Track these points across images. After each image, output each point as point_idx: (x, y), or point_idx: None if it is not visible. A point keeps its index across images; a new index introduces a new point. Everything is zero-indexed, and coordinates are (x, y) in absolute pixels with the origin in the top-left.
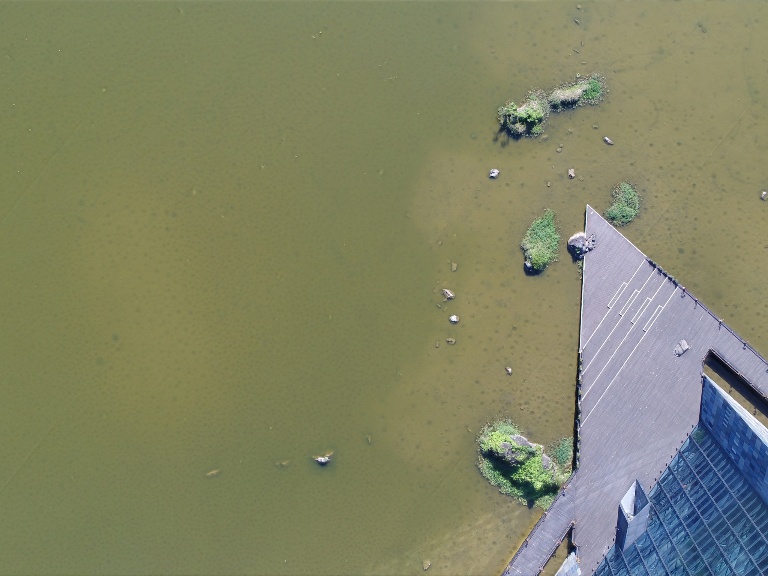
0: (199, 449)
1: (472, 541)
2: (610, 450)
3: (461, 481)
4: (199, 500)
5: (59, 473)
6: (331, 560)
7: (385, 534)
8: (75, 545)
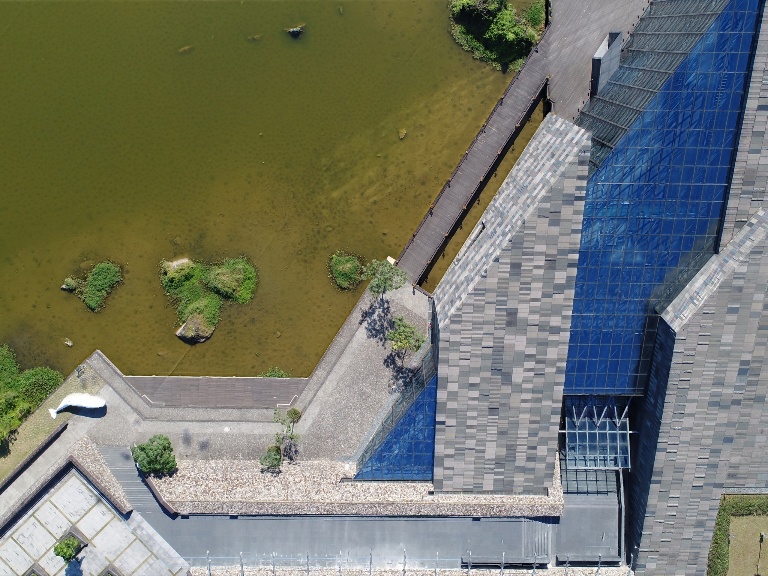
0: (170, 26)
1: (447, 108)
2: (582, 4)
3: (434, 48)
4: (172, 77)
5: (30, 55)
6: (306, 133)
7: (360, 105)
8: (48, 128)
